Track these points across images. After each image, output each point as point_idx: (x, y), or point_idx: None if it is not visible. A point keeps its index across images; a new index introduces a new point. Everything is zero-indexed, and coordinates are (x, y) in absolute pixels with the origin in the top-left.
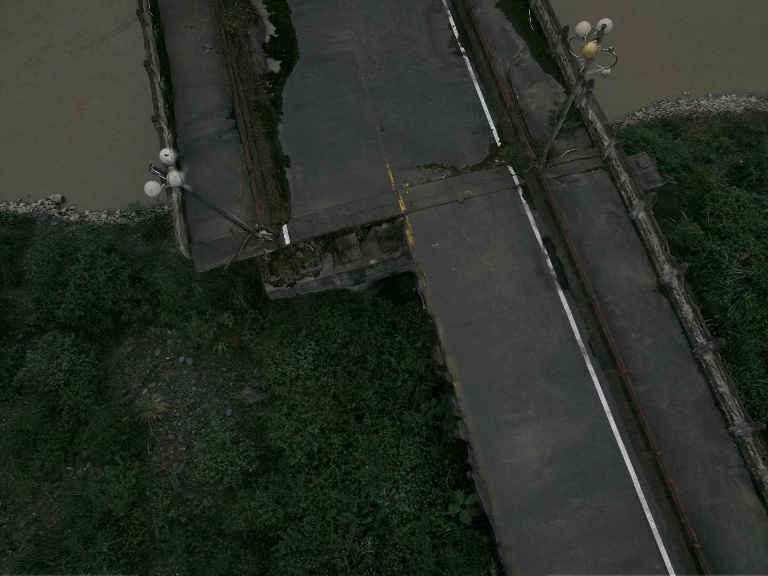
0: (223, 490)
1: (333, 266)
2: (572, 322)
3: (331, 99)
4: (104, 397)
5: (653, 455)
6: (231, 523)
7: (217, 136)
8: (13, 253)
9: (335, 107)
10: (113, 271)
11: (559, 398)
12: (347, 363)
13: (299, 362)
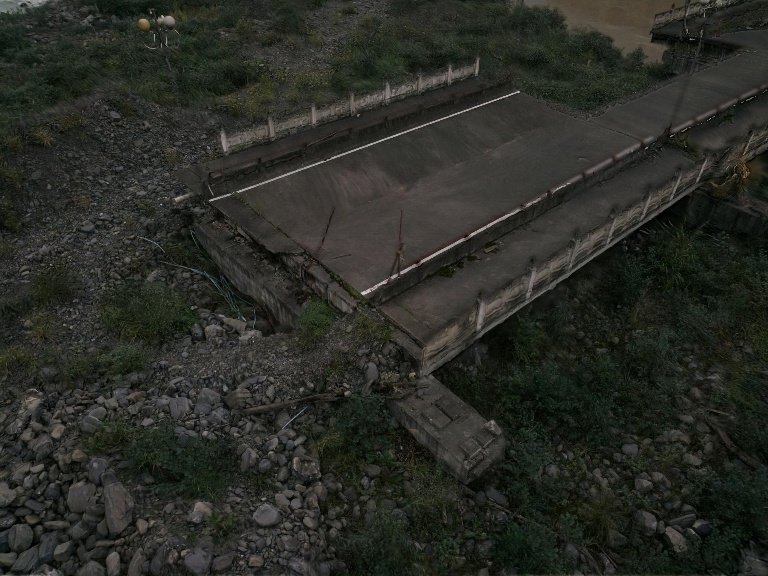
0: None
1: None
2: None
3: (759, 37)
4: None
5: None
6: None
7: None
8: None
9: (758, 38)
10: (614, 54)
11: None
12: None
13: None
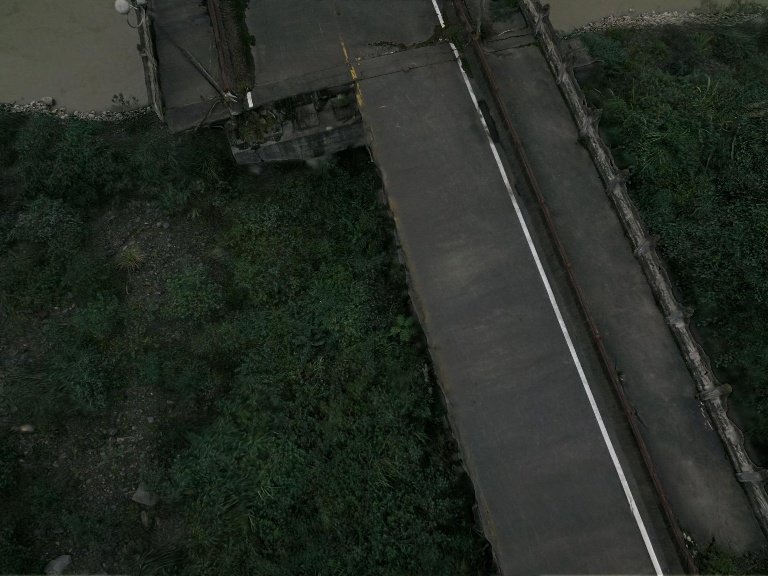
0: (193, 325)
1: (293, 132)
2: (501, 169)
3: None
4: (88, 249)
5: (565, 270)
6: (199, 347)
7: (190, 20)
8: (7, 136)
9: None
10: (97, 149)
11: (487, 230)
12: (307, 224)
13: (264, 222)
